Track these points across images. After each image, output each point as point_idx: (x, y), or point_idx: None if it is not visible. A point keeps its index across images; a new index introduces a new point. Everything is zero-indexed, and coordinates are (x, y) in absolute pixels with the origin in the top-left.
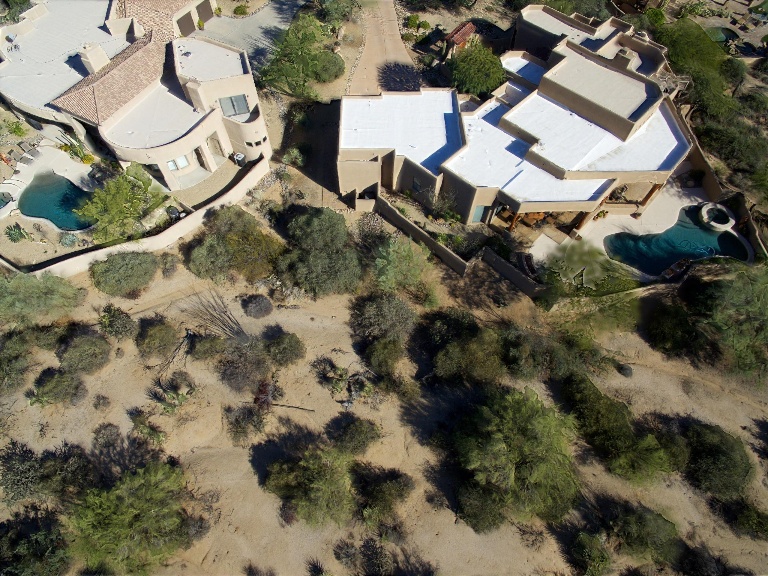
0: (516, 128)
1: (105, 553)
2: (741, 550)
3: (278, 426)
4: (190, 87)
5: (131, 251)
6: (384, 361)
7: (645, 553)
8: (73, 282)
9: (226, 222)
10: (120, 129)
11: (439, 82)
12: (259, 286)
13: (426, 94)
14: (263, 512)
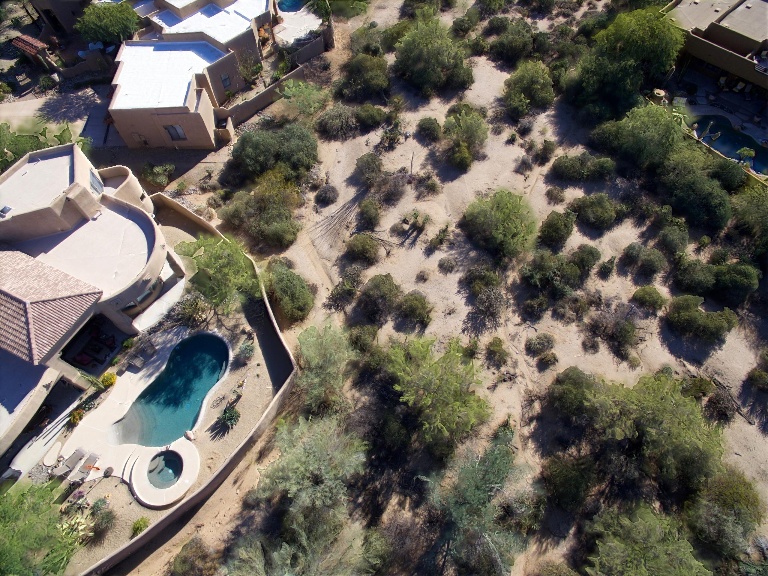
0: (193, 4)
1: (525, 249)
2: (463, 7)
3: (427, 170)
4: (77, 195)
5: (265, 292)
6: (378, 112)
7: (471, 34)
8: (297, 343)
9: (245, 207)
10: (105, 288)
11: (82, 81)
12: (307, 199)
13: (123, 61)
14: (483, 169)
